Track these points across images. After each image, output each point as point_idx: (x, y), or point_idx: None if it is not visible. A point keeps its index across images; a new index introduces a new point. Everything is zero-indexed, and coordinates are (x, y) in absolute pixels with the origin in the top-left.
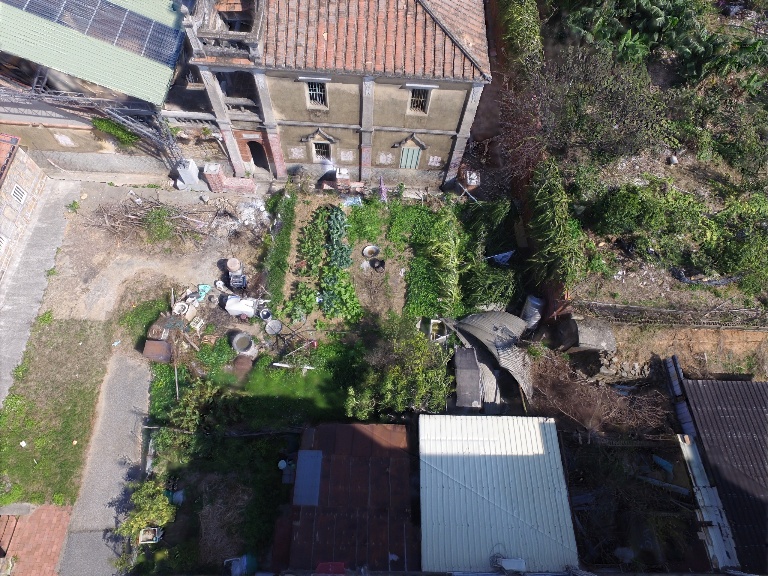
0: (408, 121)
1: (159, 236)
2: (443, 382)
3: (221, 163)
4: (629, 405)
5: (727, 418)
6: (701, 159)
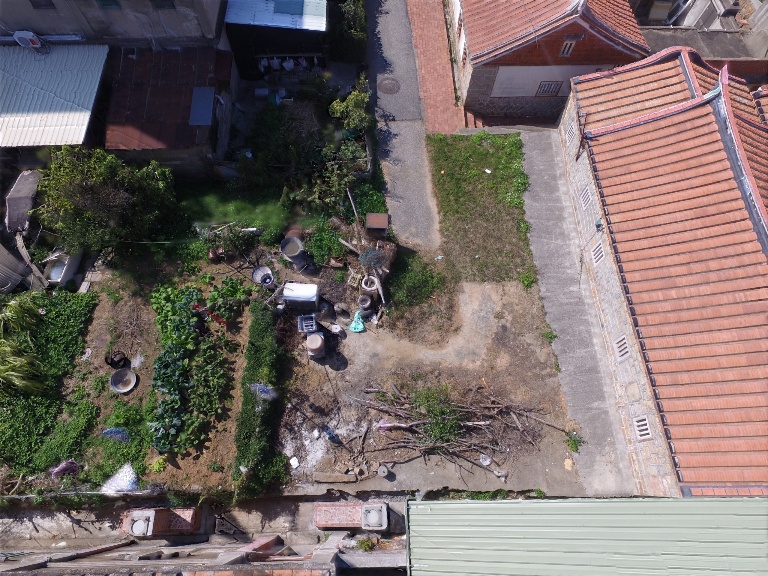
0: None
1: None
2: None
3: None
4: None
5: None
6: None
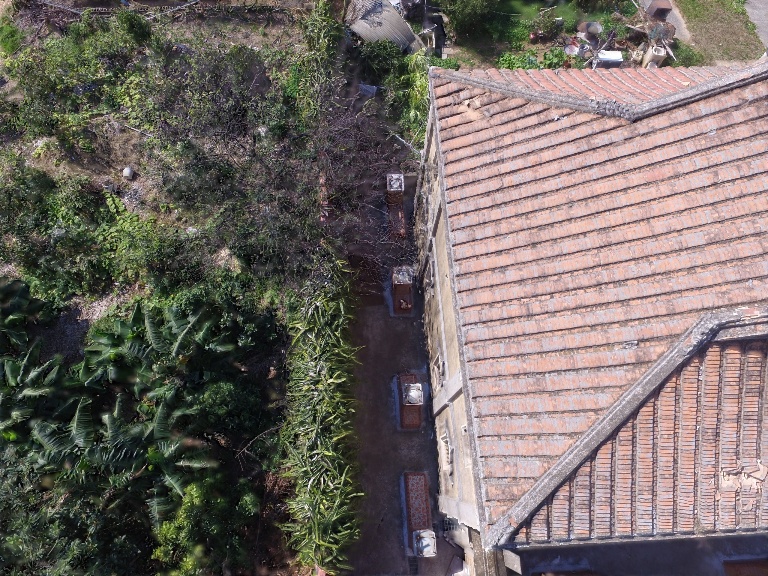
0: None
1: None
2: None
3: None
4: None
5: None
6: (87, 177)
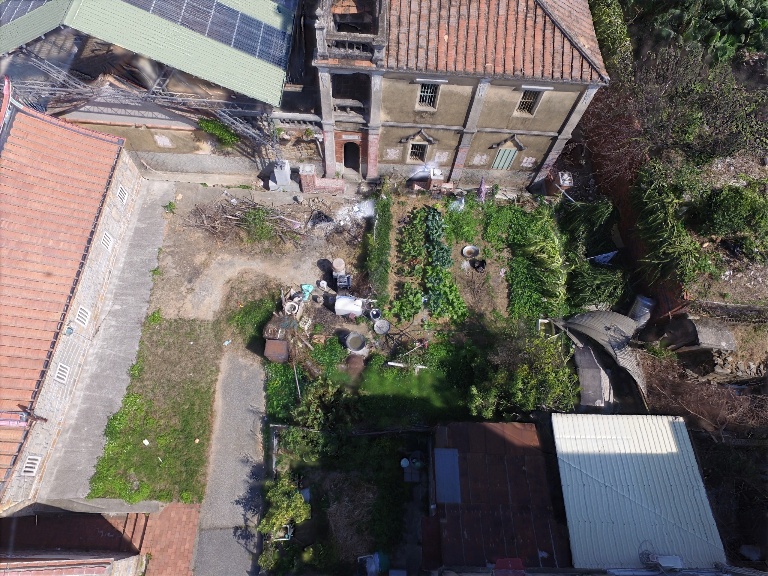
0: (512, 122)
1: (259, 236)
2: (567, 381)
3: (313, 164)
4: (749, 404)
5: None
6: None
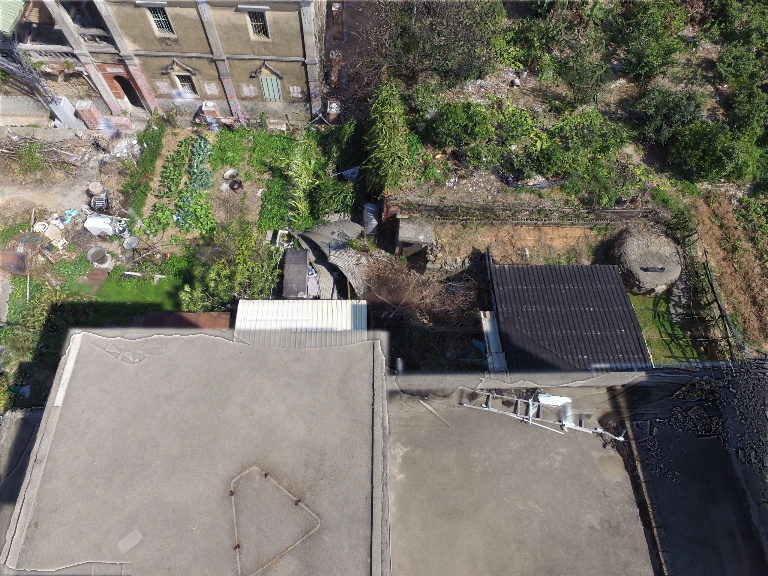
0: (255, 48)
1: (30, 167)
2: (270, 275)
3: (95, 101)
4: (446, 292)
5: (525, 295)
6: (542, 81)
